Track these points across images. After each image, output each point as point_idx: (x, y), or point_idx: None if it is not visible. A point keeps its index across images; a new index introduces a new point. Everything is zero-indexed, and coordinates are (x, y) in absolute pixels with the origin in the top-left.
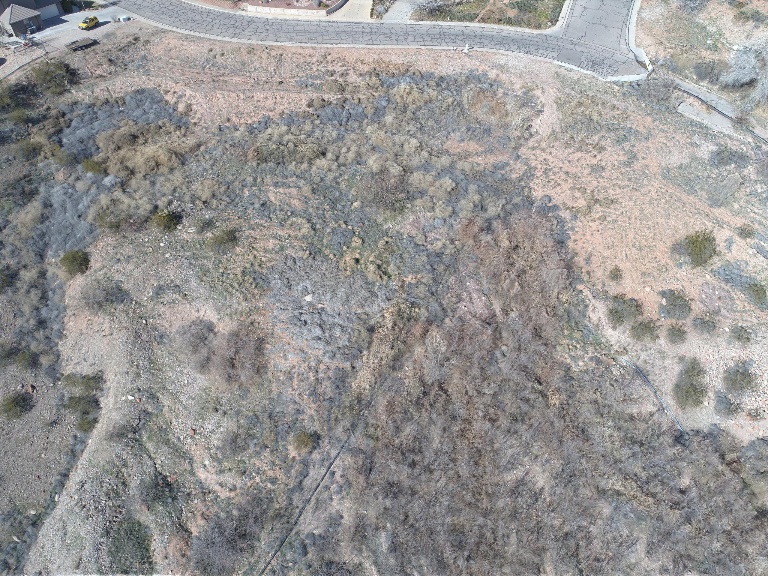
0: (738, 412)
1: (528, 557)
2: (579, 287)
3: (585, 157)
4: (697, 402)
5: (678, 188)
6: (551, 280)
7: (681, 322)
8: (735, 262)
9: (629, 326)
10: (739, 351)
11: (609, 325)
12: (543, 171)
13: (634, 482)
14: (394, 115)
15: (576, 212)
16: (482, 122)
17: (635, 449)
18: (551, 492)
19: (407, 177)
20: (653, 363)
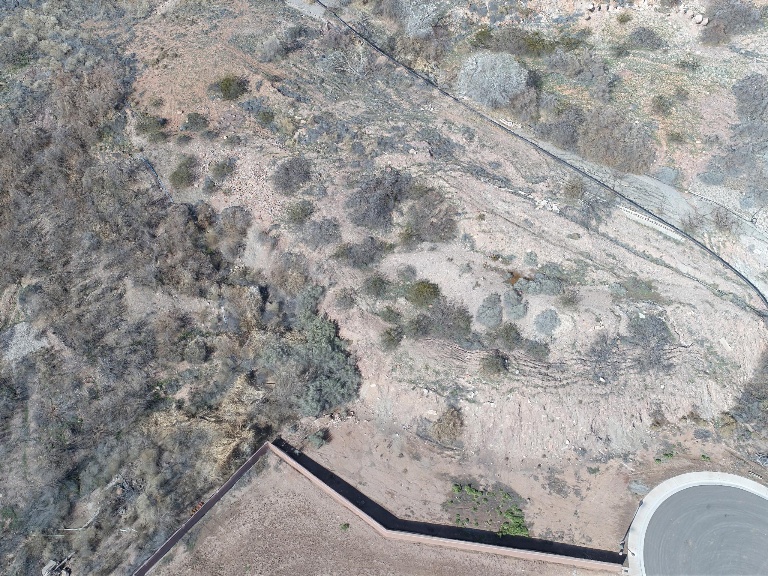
0: (218, 191)
1: (10, 265)
2: (126, 111)
3: (178, 29)
4: (189, 184)
5: (237, 49)
6: (97, 102)
7: (193, 133)
8: (260, 98)
9: (150, 134)
10: (228, 151)
11: (135, 133)
12: (141, 38)
13: (108, 225)
14: (50, 3)
15: (146, 63)
16: (121, 8)
17: (116, 205)
18: (51, 233)
19: (38, 44)
20: (161, 158)
